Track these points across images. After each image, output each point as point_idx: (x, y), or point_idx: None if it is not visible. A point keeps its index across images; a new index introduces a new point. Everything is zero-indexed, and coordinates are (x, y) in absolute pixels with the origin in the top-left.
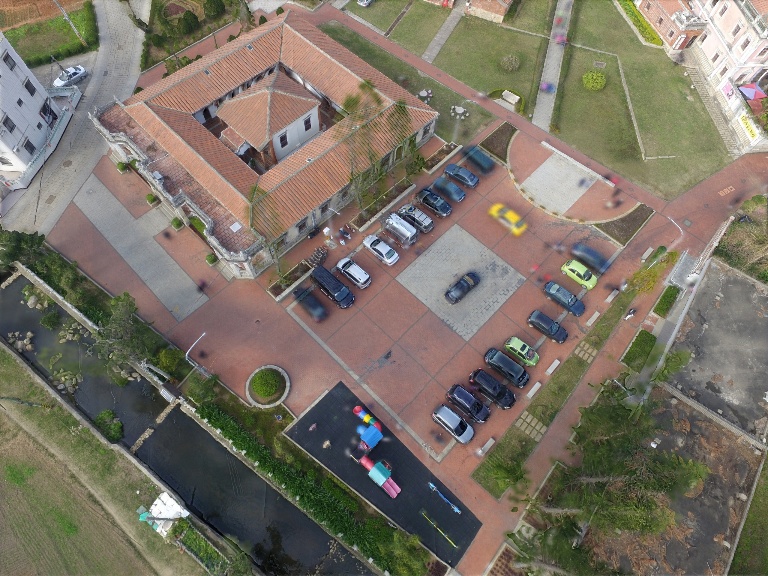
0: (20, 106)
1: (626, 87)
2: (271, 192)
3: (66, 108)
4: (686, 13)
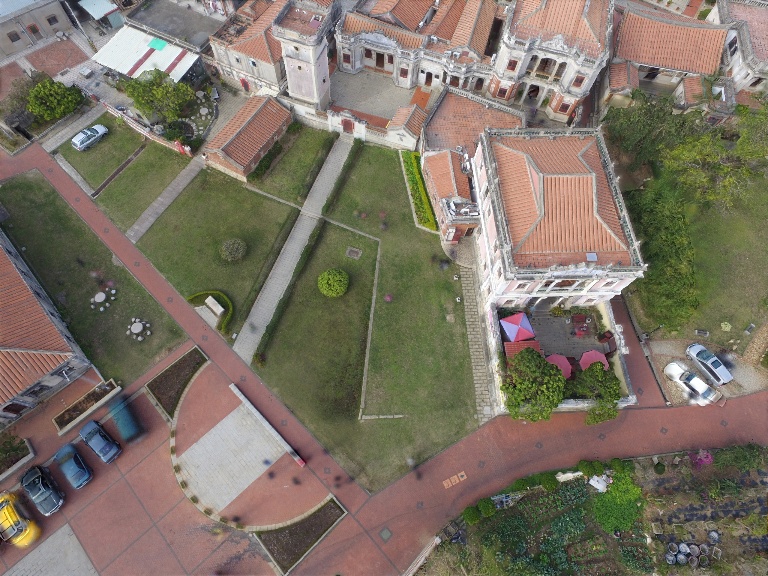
0: None
1: (374, 294)
2: None
3: None
4: (456, 200)
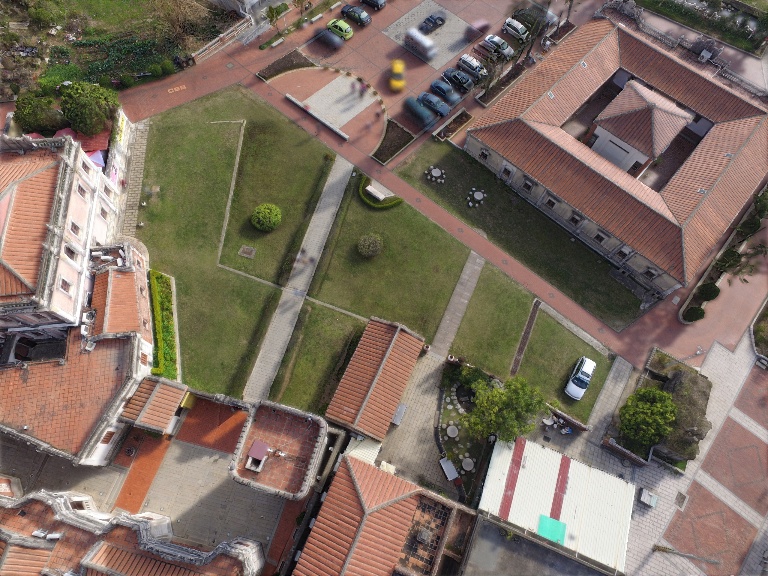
0: None
1: (227, 211)
2: None
3: None
4: (113, 267)
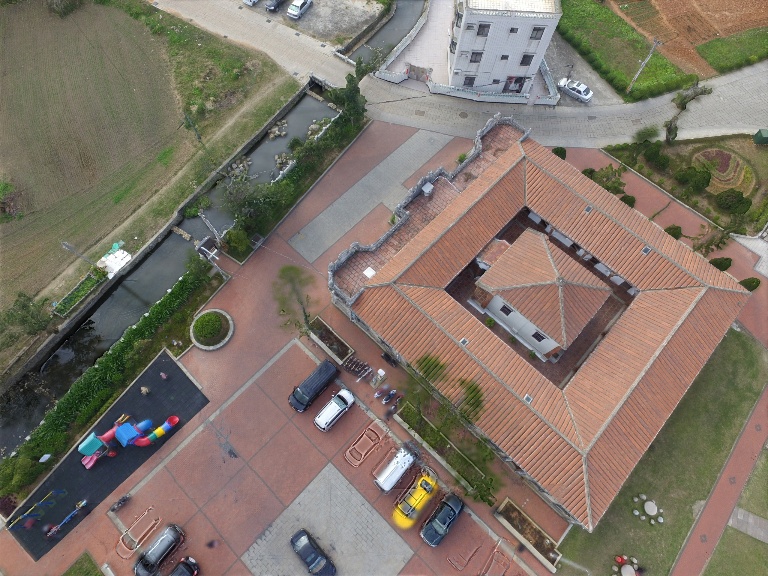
0: (502, 59)
1: None
2: (410, 302)
3: (528, 96)
4: None
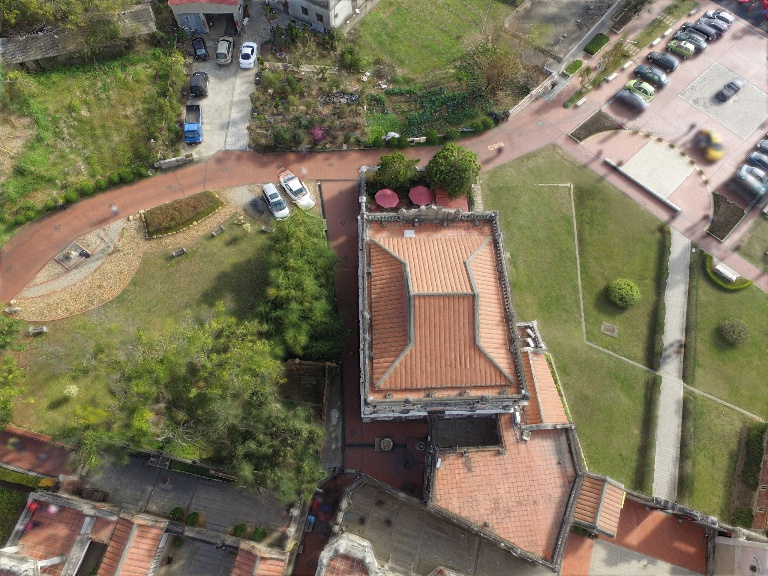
0: None
1: (580, 283)
2: None
3: None
4: None
